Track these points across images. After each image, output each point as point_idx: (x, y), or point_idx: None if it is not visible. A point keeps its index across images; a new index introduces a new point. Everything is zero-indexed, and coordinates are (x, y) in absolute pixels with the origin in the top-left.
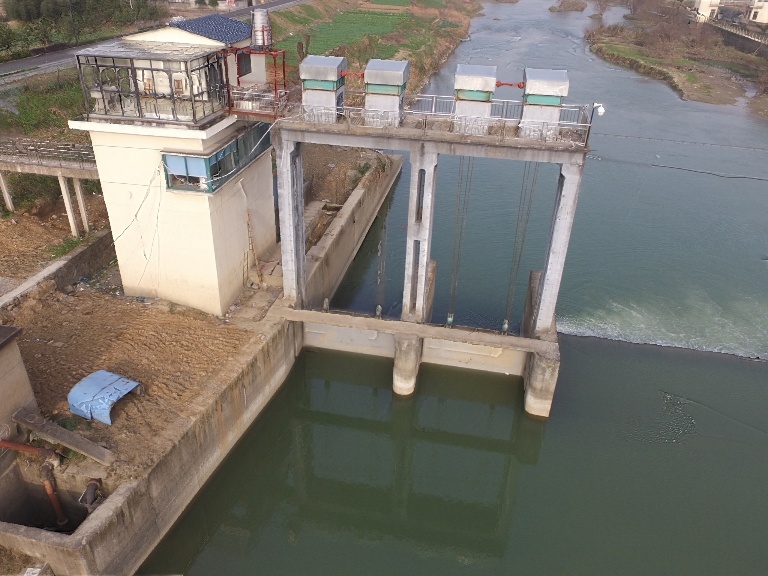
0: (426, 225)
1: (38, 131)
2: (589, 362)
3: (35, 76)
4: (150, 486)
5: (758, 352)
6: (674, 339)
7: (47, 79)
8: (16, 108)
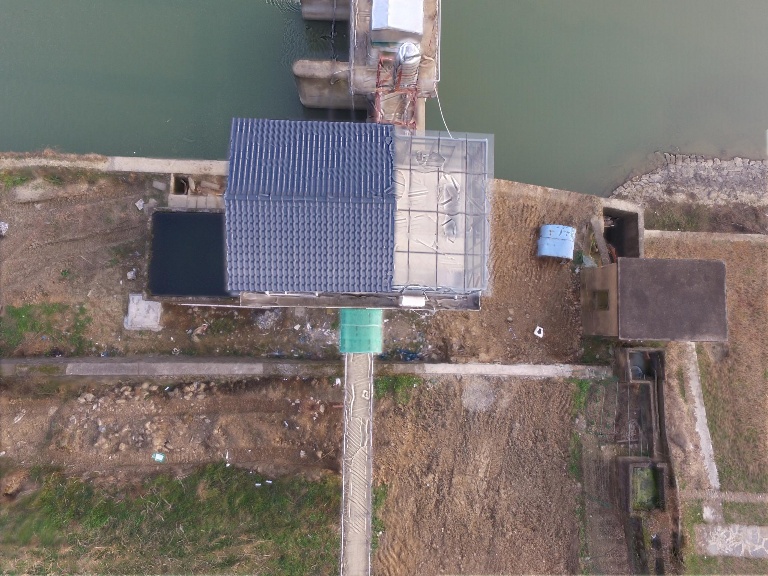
0: None
1: None
2: None
3: None
4: None
5: None
6: None
7: None
8: None
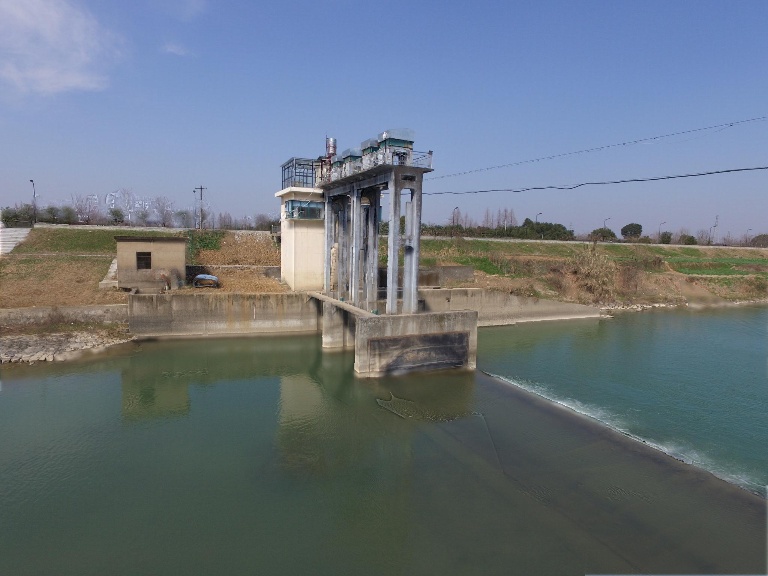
0: (354, 236)
1: None
2: (465, 384)
3: None
4: (172, 302)
5: (671, 449)
6: (582, 409)
7: None
8: None
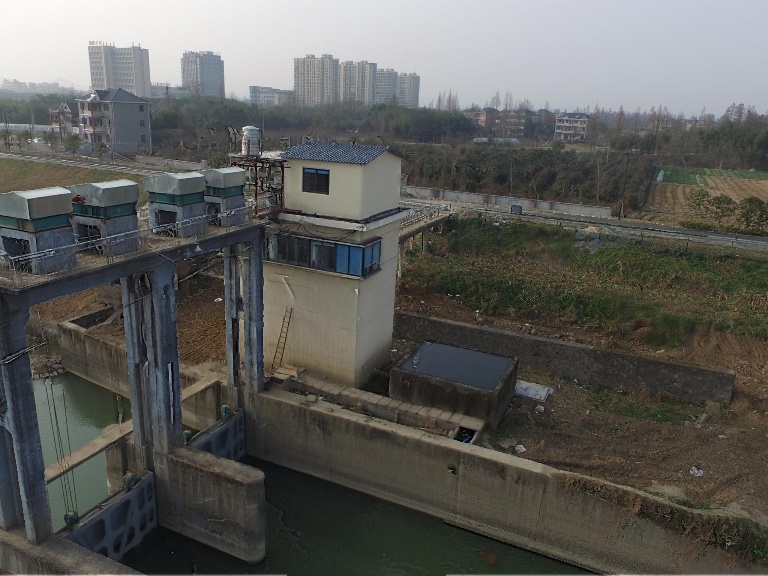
0: None
1: (576, 270)
2: None
3: (685, 240)
4: None
5: None
6: None
7: (684, 245)
8: (597, 250)
